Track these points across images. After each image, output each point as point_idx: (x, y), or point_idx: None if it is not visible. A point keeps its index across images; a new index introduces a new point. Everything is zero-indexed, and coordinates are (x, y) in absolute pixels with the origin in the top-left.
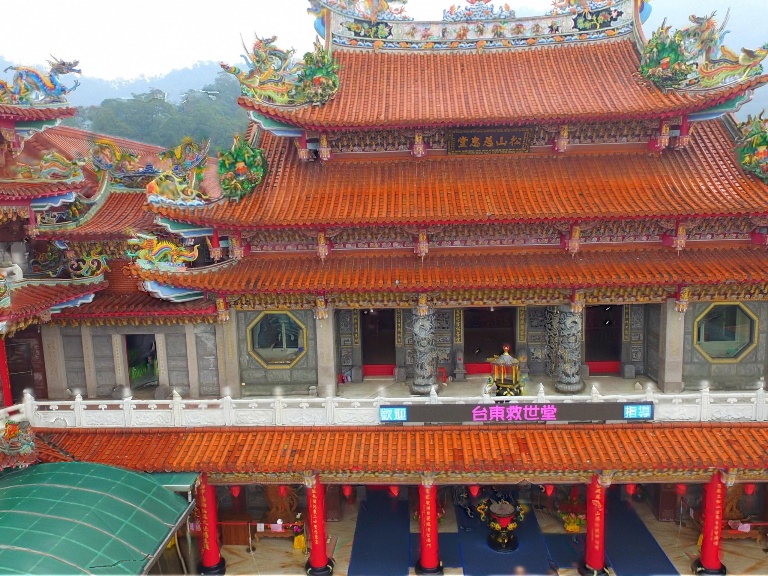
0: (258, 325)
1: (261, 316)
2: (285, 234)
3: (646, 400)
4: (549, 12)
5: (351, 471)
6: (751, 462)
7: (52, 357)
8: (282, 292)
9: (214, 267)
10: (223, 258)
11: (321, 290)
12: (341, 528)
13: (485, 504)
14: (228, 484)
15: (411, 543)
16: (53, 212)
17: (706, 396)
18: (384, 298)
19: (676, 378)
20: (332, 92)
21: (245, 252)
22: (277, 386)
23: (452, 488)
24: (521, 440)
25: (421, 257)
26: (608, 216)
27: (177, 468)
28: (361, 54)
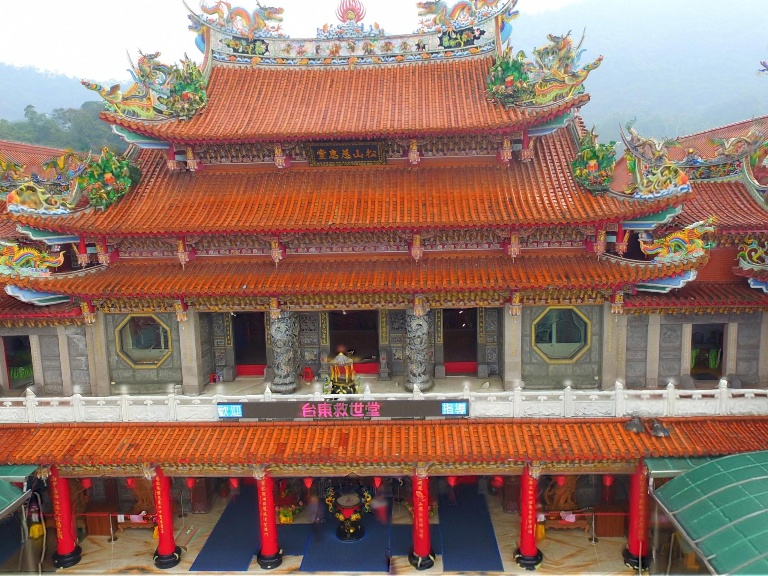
0: (127, 327)
1: (128, 319)
2: (149, 241)
3: (463, 398)
4: (416, 31)
5: (190, 464)
6: (544, 455)
7: None
8: (138, 296)
9: (81, 272)
10: (93, 264)
11: (174, 294)
12: (205, 520)
13: (332, 496)
14: (78, 477)
15: None
16: None
17: (518, 394)
18: (241, 302)
19: (516, 378)
20: (199, 107)
21: (112, 258)
22: (145, 385)
23: (318, 482)
24: (344, 435)
25: (276, 263)
26: (440, 225)
27: (19, 461)
28: (239, 69)
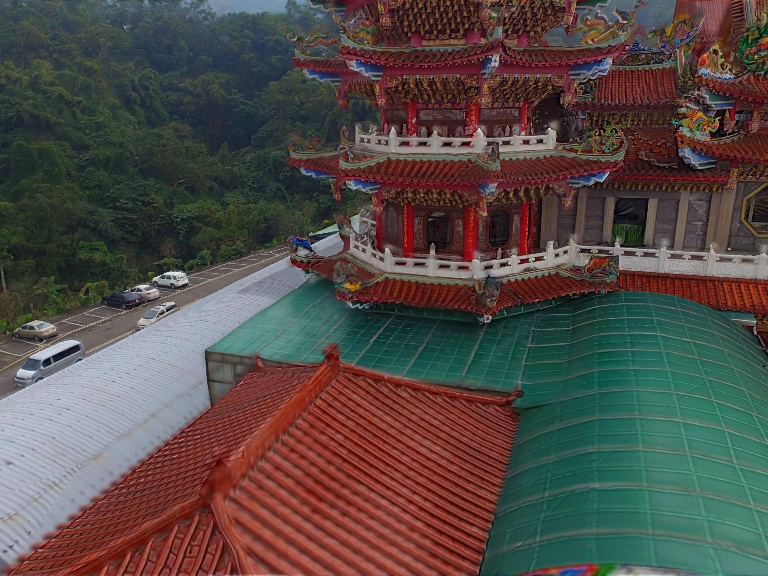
0: (754, 196)
1: (762, 187)
2: None
3: None
4: None
5: None
6: None
7: (549, 213)
8: None
9: (727, 139)
10: None
11: None
12: None
13: None
14: None
15: None
16: (581, 85)
17: None
18: None
19: None
20: None
21: None
22: None
23: None
24: None
25: None
26: None
27: (733, 308)
28: None
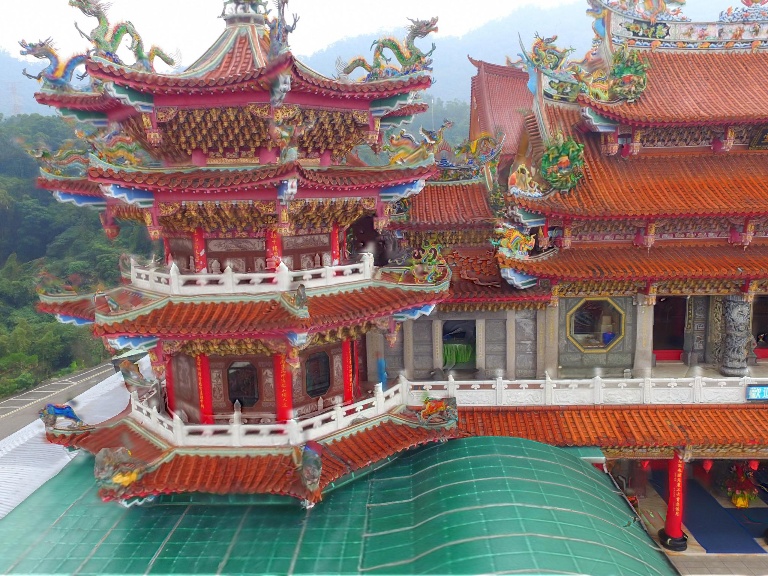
0: (575, 311)
1: (582, 302)
2: (610, 224)
3: None
4: None
5: (723, 446)
6: None
7: (374, 342)
8: (626, 279)
9: (544, 256)
10: None
11: (666, 277)
12: (653, 504)
13: None
14: None
15: (734, 517)
16: None
17: None
18: (707, 285)
19: None
20: (642, 90)
21: None
22: (592, 369)
23: None
24: None
25: (743, 246)
26: None
27: (579, 442)
28: (639, 53)
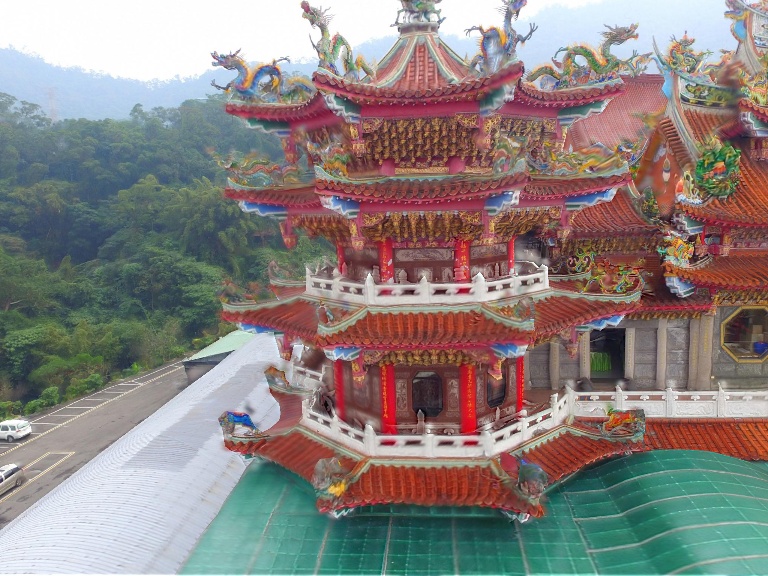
0: None
1: (738, 311)
2: None
3: None
4: None
5: None
6: None
7: None
8: None
9: (701, 264)
10: None
11: None
12: None
13: None
14: None
15: None
16: None
17: None
18: None
19: None
20: None
21: None
22: (747, 379)
23: None
24: None
25: None
26: None
27: (765, 456)
28: None
